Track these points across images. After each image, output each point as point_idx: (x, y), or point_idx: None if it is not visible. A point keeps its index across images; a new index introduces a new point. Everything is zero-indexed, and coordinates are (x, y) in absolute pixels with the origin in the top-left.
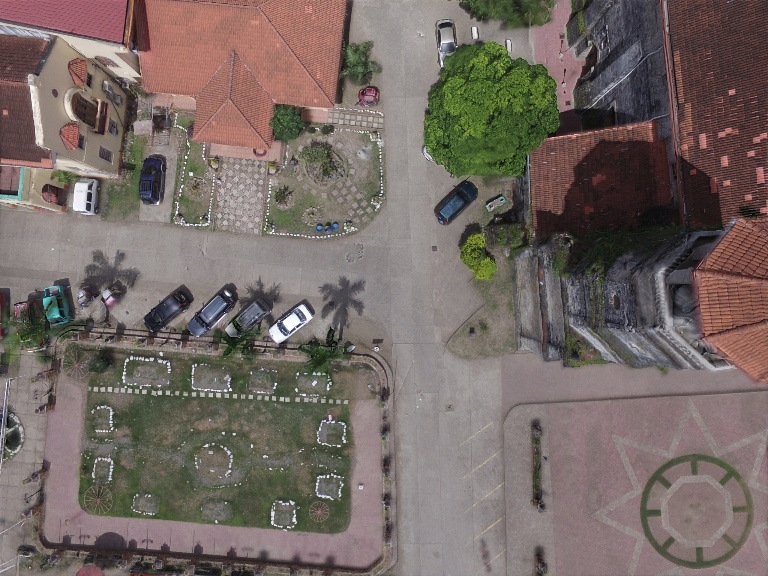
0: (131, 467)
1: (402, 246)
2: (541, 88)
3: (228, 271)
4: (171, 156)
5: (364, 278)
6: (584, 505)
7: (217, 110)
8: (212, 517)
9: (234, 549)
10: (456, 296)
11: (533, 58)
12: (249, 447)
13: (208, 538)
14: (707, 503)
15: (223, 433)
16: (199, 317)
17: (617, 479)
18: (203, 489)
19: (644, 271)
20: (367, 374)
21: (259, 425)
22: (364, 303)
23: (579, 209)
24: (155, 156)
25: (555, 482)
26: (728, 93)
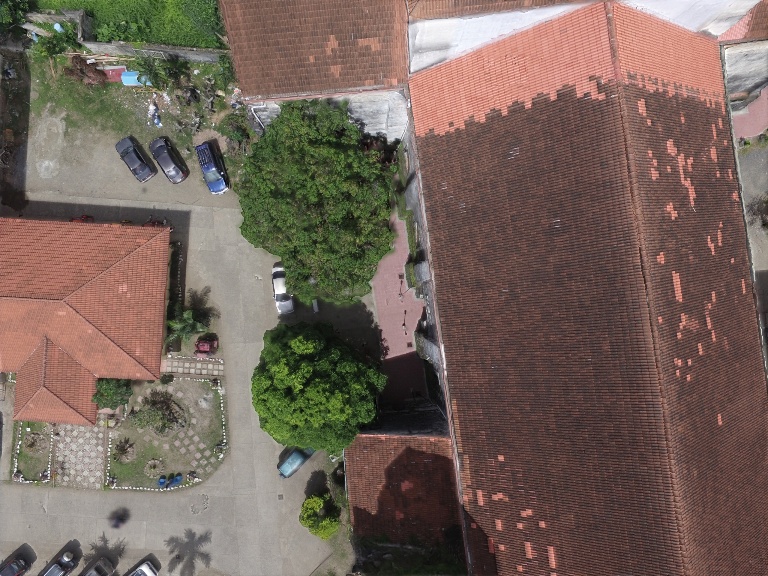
0: None
1: (247, 495)
2: (338, 406)
3: (71, 527)
4: (8, 411)
5: (210, 529)
6: None
7: (33, 396)
8: None
9: None
10: (304, 544)
11: (373, 299)
12: None
13: None
14: None
15: None
16: None
17: None
18: None
19: None
20: None
21: None
22: (211, 555)
23: (390, 512)
24: None
25: None
26: (498, 458)
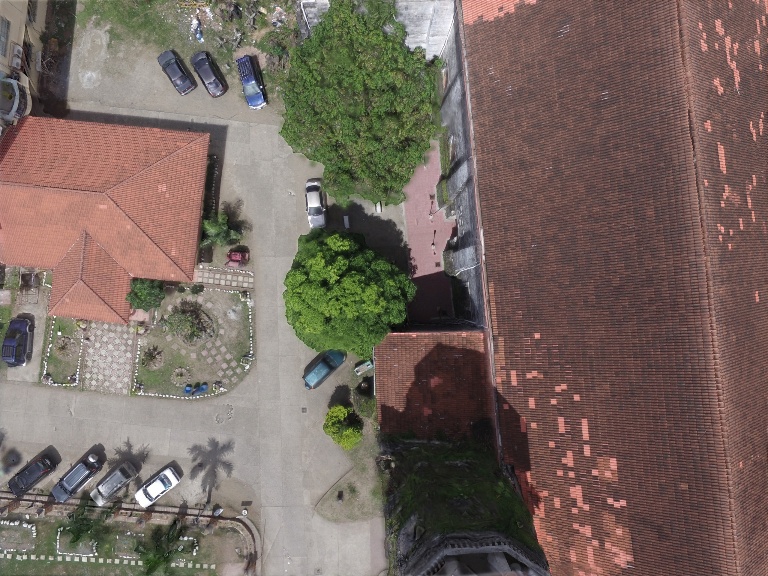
0: None
1: (271, 407)
2: (373, 296)
3: (96, 432)
4: (40, 315)
5: (233, 439)
6: None
7: (69, 289)
8: None
9: None
10: (325, 458)
11: (404, 218)
12: None
13: None
14: None
15: None
16: (62, 484)
17: None
18: None
19: (409, 567)
20: (235, 538)
21: None
22: (233, 465)
23: (419, 409)
24: (22, 316)
25: None
26: (534, 336)
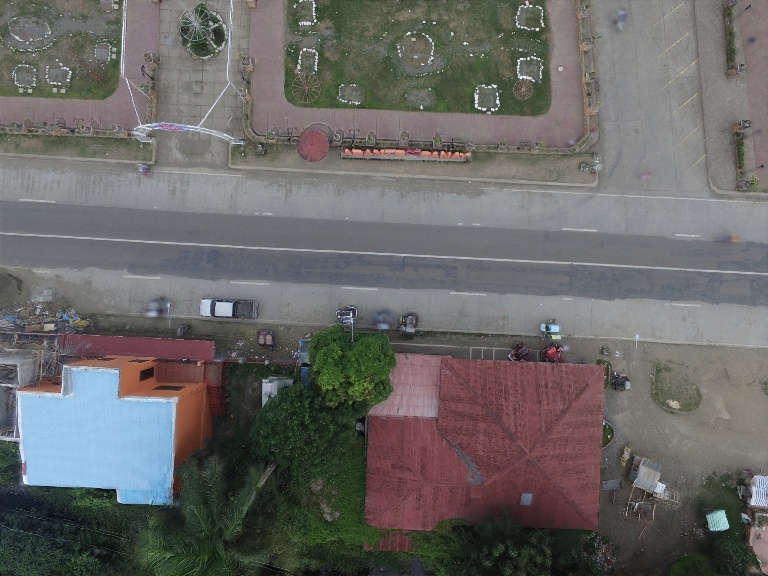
0: (335, 59)
1: None
2: None
3: None
4: None
5: None
6: None
7: None
8: (417, 103)
9: (439, 134)
10: None
11: None
12: (449, 35)
13: (413, 125)
14: None
15: (424, 22)
16: None
17: None
18: (406, 78)
19: None
20: None
21: (458, 14)
22: None
23: None
24: None
25: (747, 55)
26: None
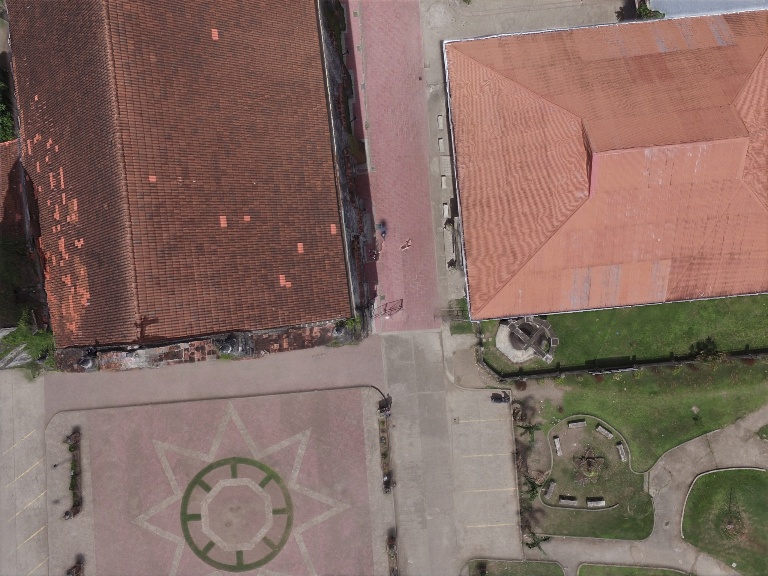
0: None
1: None
2: None
3: None
4: None
5: None
6: (125, 511)
7: None
8: None
9: None
10: None
11: None
12: None
13: None
14: (247, 506)
15: None
16: None
17: (157, 484)
18: None
19: None
20: None
21: None
22: None
23: (12, 216)
24: None
25: (96, 489)
26: (35, 99)
